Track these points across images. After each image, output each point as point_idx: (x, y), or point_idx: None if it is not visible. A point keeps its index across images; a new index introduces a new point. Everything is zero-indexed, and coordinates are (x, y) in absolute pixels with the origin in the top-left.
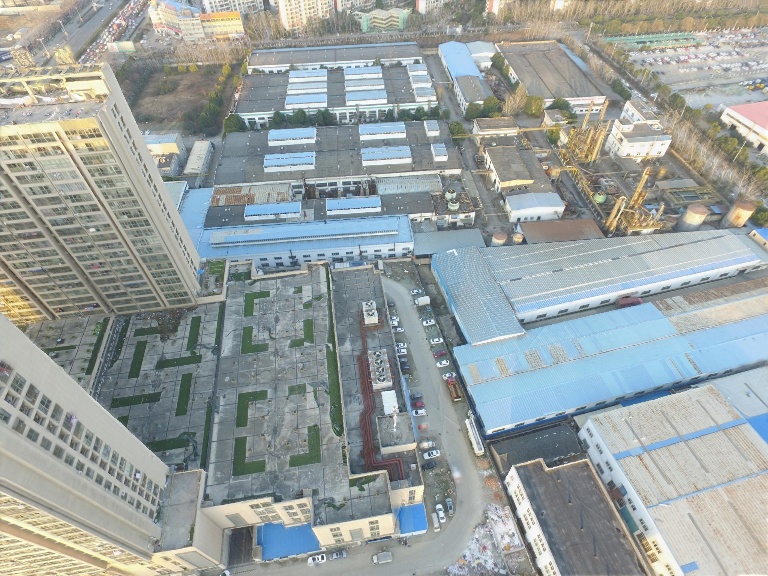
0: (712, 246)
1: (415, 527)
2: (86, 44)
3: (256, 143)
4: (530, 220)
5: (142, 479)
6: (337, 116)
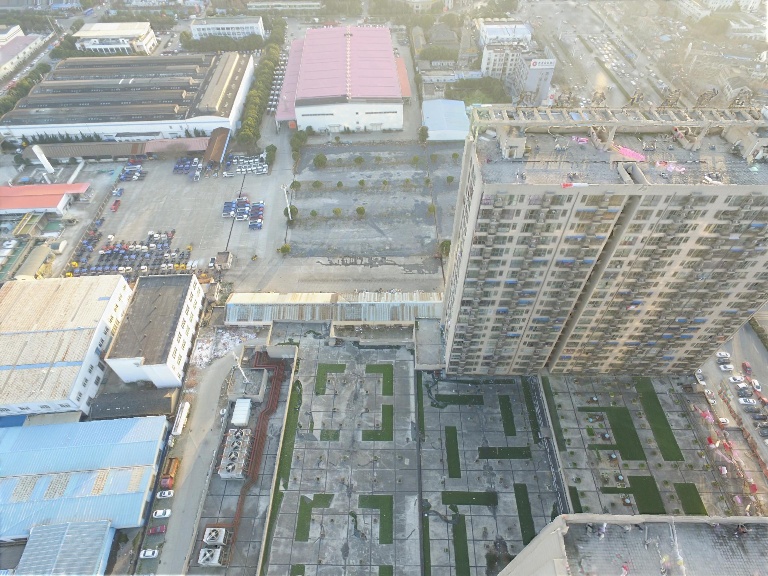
0: None
1: None
2: None
3: None
4: None
5: (448, 326)
6: None
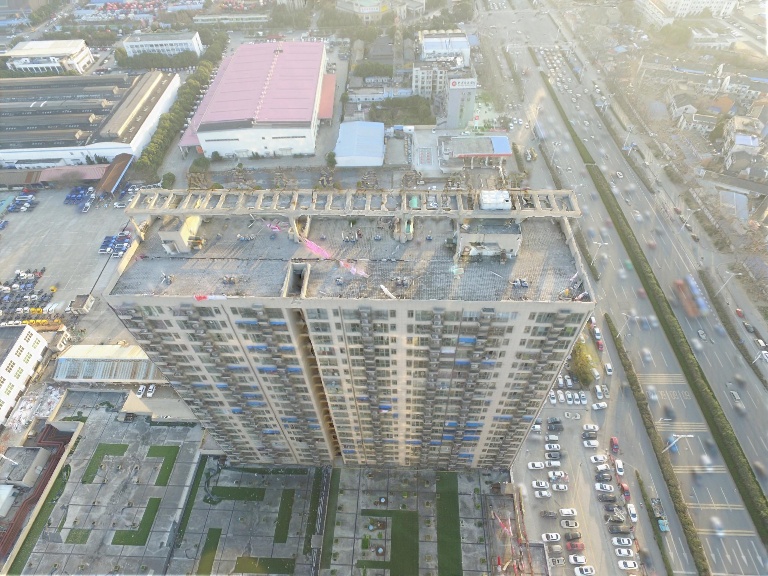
0: None
1: None
2: None
3: None
4: None
5: None
6: None
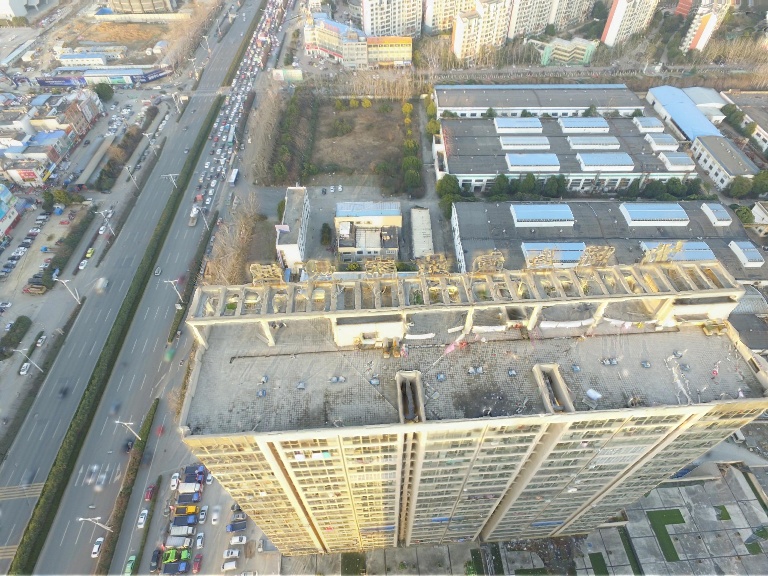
0: None
1: None
2: (234, 64)
3: (498, 221)
4: None
5: None
6: (569, 182)
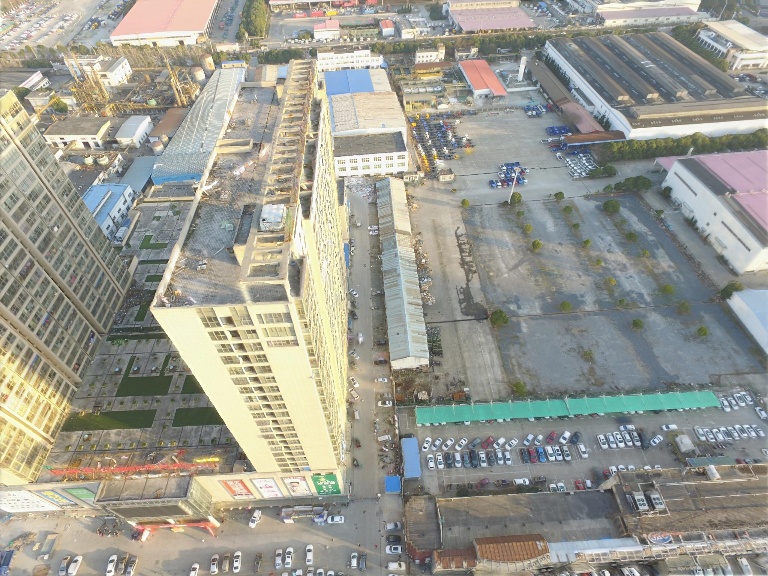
0: (225, 77)
1: (347, 205)
2: None
3: None
4: (144, 139)
5: None
6: None
